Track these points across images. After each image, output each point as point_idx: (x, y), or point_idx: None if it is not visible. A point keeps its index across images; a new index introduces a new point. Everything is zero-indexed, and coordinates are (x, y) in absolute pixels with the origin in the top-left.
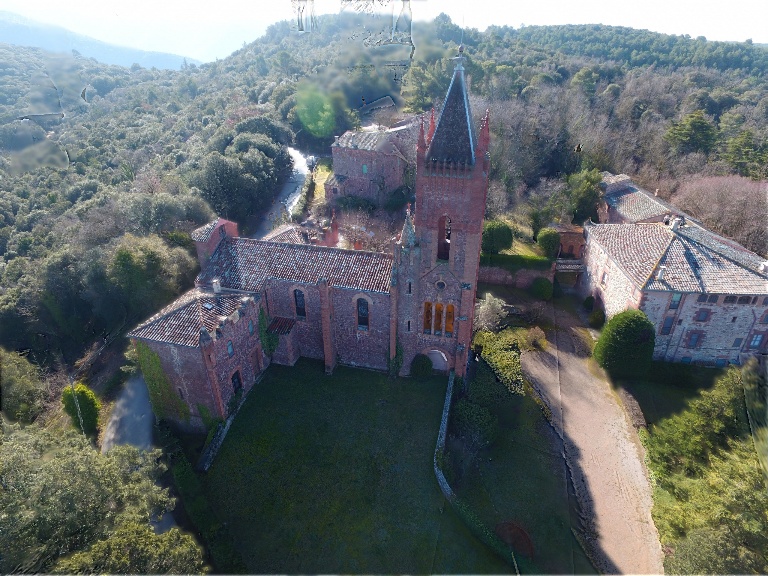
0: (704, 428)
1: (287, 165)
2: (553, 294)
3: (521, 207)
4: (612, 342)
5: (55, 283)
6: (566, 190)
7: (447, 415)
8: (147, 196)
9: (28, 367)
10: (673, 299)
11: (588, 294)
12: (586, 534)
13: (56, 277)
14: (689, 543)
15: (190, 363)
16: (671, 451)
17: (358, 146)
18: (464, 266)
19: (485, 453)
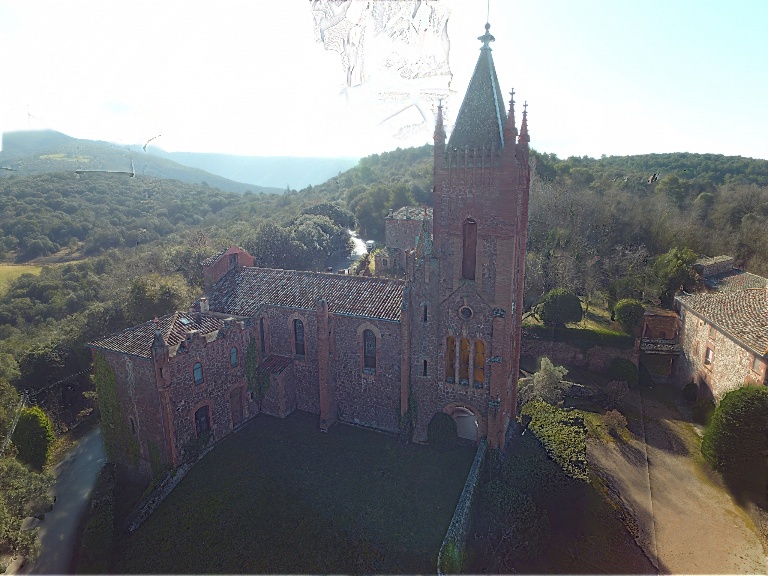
0: None
1: (347, 248)
2: (639, 381)
3: (592, 277)
4: (727, 430)
5: (89, 330)
6: (648, 258)
7: (470, 498)
8: (191, 249)
9: (12, 396)
10: None
11: (688, 382)
12: None
13: (91, 324)
14: None
15: (143, 382)
16: None
17: (411, 217)
18: (495, 285)
19: (527, 568)
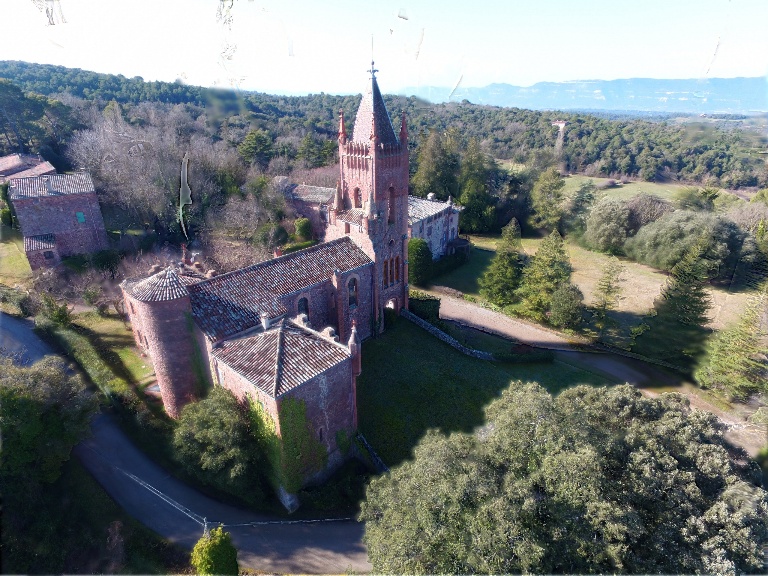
0: (508, 264)
1: None
2: None
3: (268, 210)
4: (417, 262)
5: None
6: (290, 188)
7: None
8: None
9: None
10: (420, 226)
11: None
12: (515, 341)
13: None
14: (558, 299)
15: (336, 385)
16: (503, 284)
17: (60, 191)
18: (402, 222)
19: None
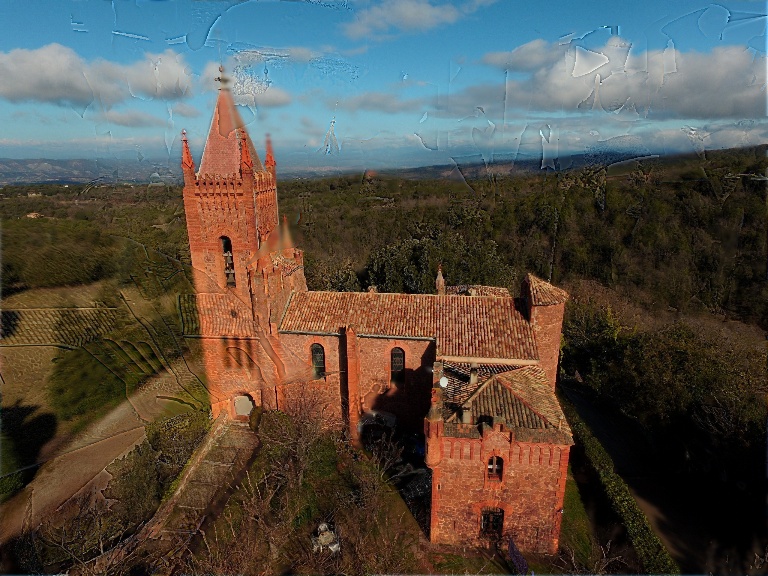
0: None
1: None
2: None
3: None
4: None
5: None
6: None
7: None
8: None
9: None
10: None
11: None
12: None
13: None
14: None
15: None
16: None
17: None
18: None
19: None
